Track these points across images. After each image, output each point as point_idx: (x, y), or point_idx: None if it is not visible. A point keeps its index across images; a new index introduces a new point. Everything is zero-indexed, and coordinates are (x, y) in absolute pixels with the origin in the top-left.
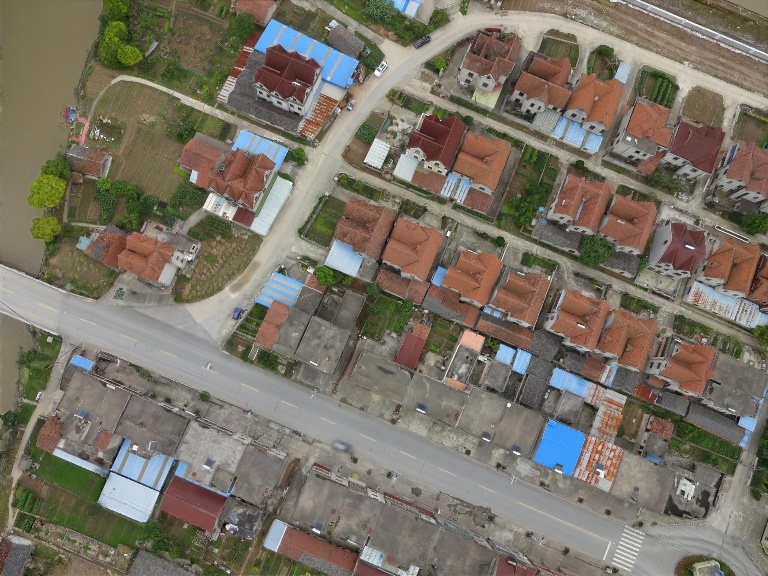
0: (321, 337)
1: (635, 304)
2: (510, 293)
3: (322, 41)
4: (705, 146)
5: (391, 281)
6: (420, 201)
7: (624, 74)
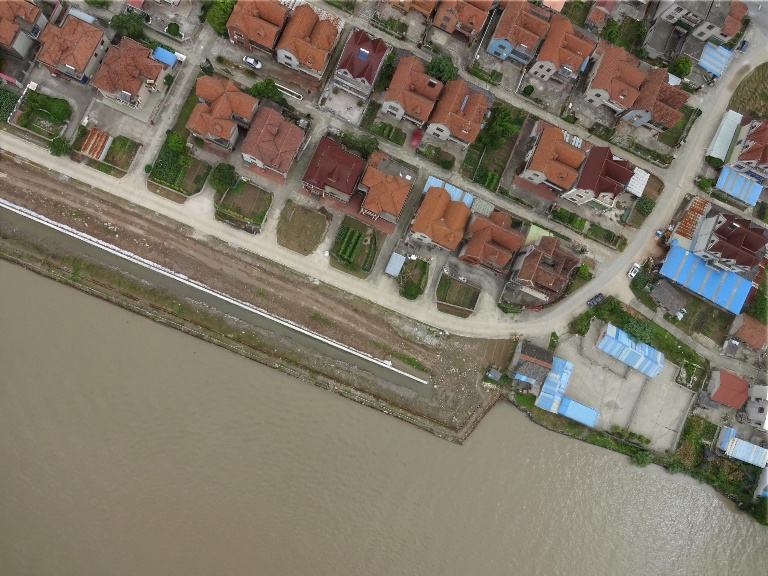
0: (698, 1)
1: (395, 26)
2: (533, 29)
3: (686, 301)
4: (335, 159)
5: (627, 59)
6: (594, 140)
7: (394, 263)
